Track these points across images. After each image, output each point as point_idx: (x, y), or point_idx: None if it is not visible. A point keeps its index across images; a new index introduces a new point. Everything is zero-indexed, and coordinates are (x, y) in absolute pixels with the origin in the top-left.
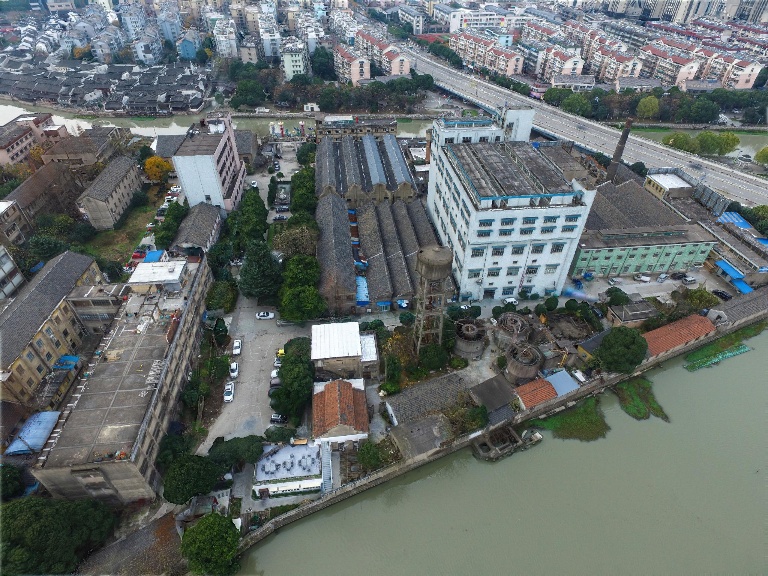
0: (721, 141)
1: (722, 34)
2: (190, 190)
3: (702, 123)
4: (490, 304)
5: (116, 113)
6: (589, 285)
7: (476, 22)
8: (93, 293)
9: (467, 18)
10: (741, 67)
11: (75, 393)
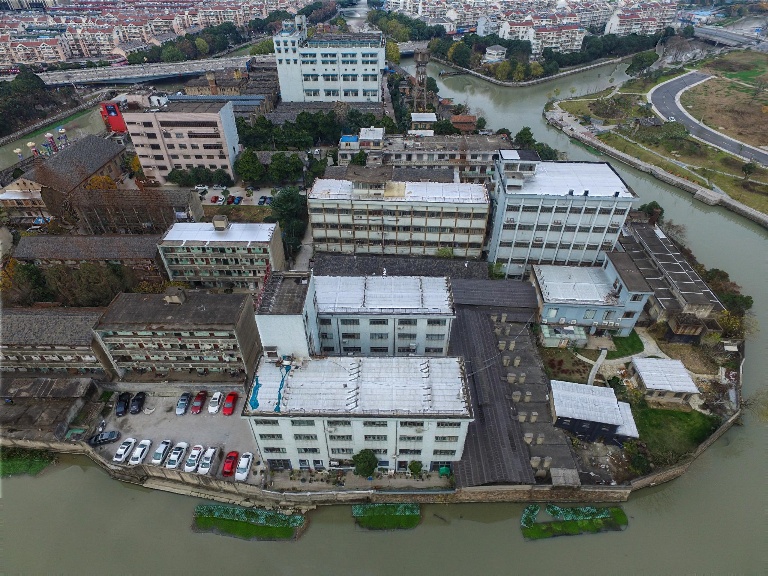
0: None
1: None
2: (228, 146)
3: (226, 49)
4: None
5: None
6: None
7: None
8: (377, 161)
9: None
10: (195, 15)
11: (469, 151)
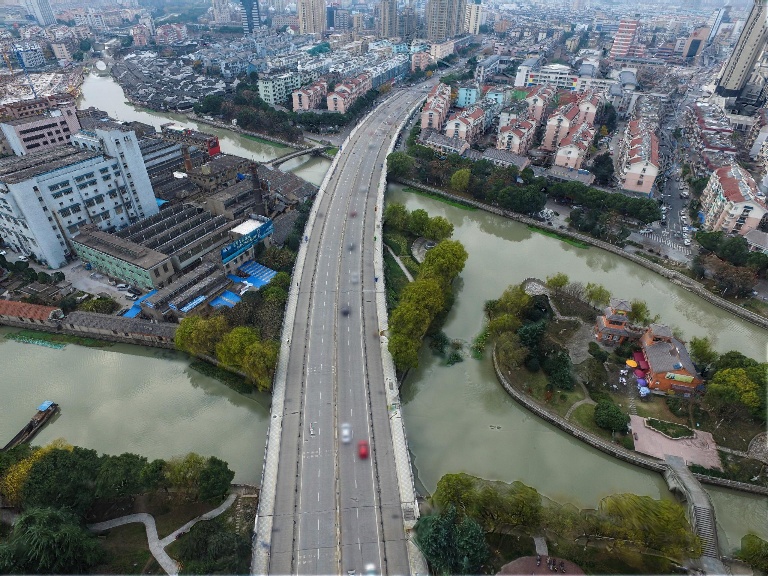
0: (424, 222)
1: (760, 129)
2: (14, 146)
3: (516, 212)
4: (17, 256)
5: (142, 104)
6: (82, 272)
7: (544, 79)
8: None
9: (534, 74)
10: (627, 163)
11: None
